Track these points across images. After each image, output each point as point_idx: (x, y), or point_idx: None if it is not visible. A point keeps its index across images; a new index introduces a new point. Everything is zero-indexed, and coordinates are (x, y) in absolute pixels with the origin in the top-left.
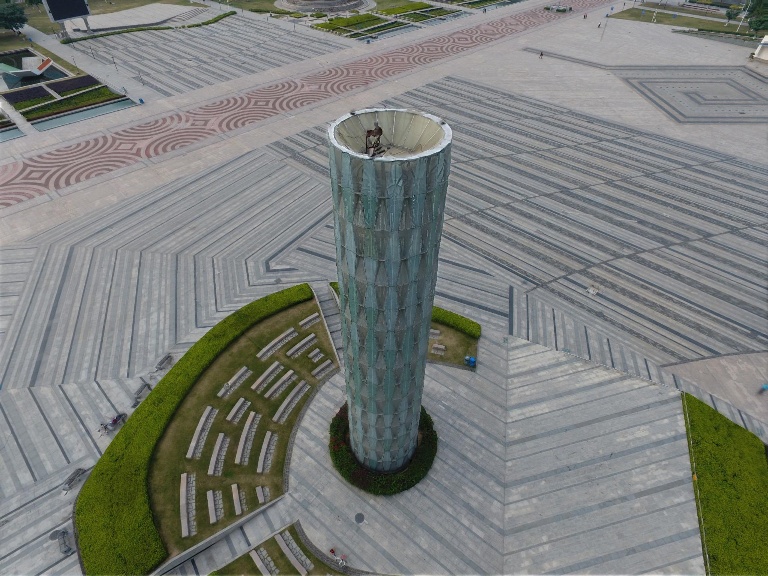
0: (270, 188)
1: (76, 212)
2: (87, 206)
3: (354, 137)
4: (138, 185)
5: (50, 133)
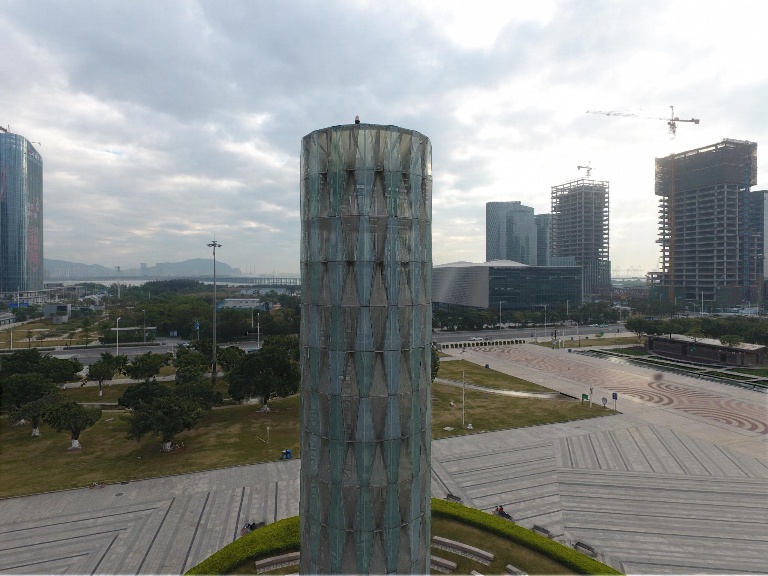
0: None
1: None
2: None
3: None
4: None
5: None
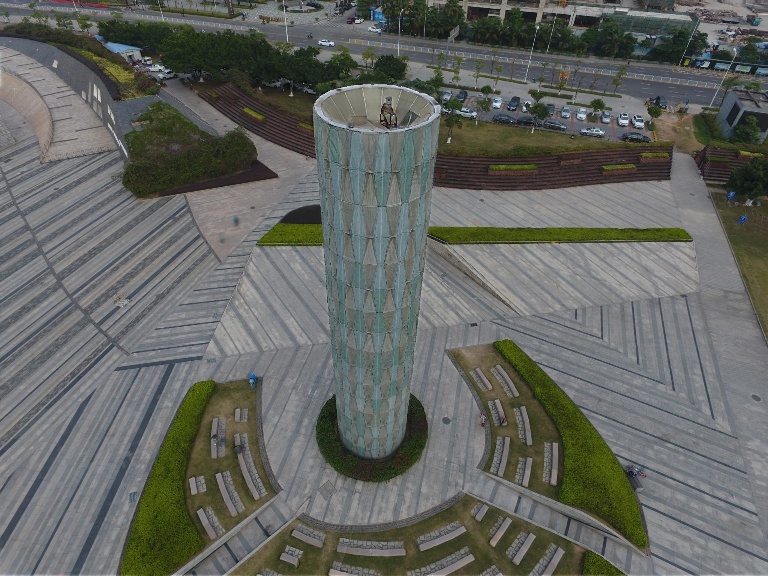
0: None
1: None
2: None
3: None
4: None
5: None
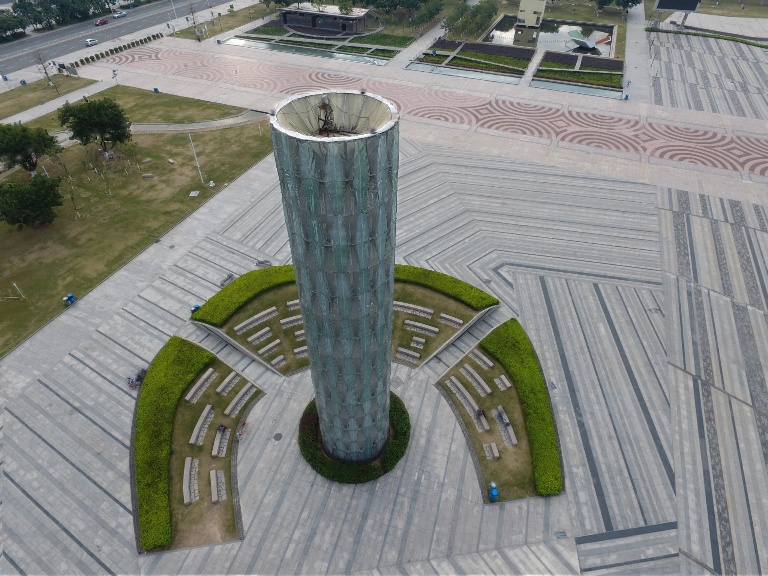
0: (606, 221)
1: (466, 146)
2: (476, 146)
3: (344, 111)
4: (523, 153)
5: (532, 90)
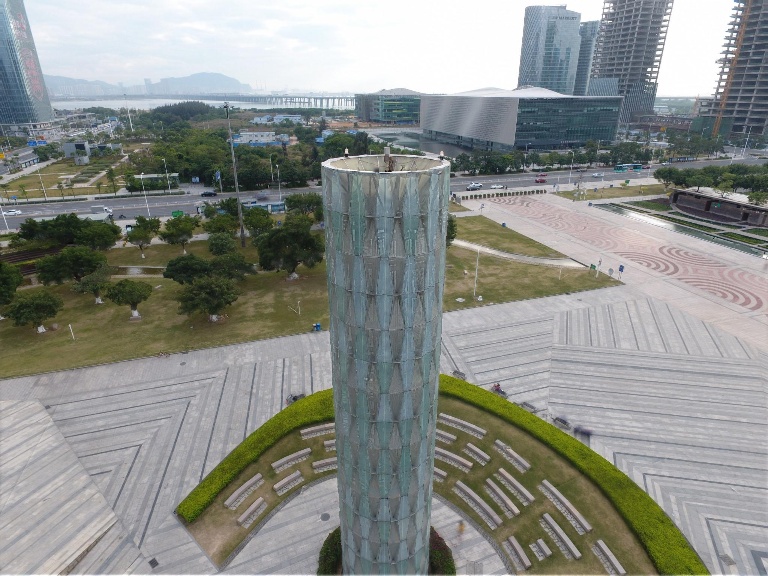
0: None
1: None
2: None
3: None
4: None
5: None
